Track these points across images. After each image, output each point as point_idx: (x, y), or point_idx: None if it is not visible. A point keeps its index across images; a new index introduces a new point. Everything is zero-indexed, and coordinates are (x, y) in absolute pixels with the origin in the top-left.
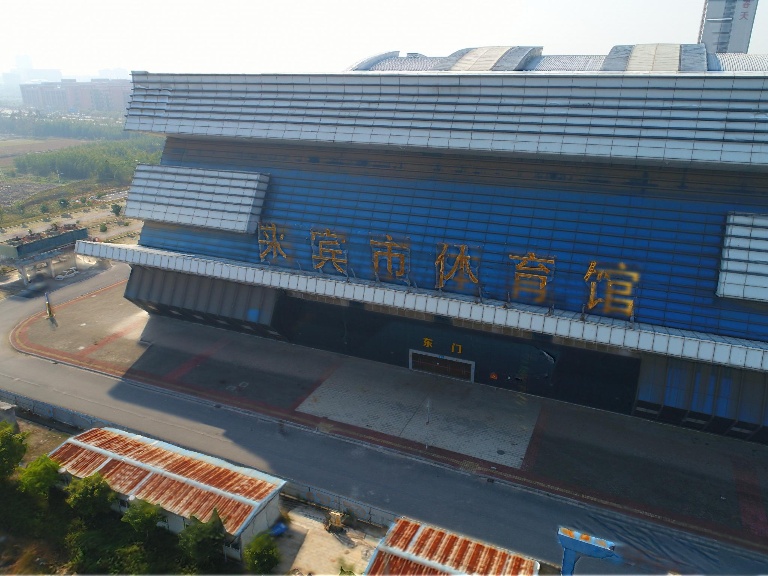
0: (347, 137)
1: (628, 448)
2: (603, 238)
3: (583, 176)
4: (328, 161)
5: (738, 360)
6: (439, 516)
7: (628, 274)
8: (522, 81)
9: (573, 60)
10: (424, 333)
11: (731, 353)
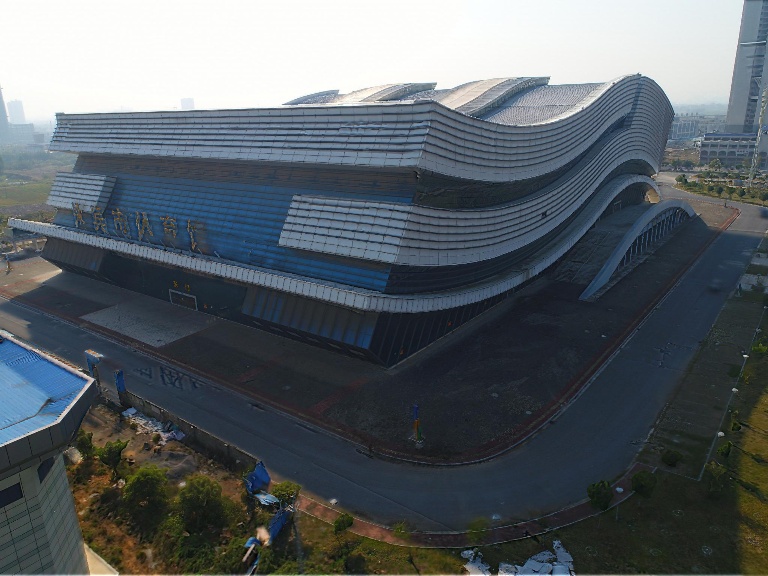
0: (135, 151)
1: (234, 344)
2: (248, 213)
3: (249, 173)
4: (143, 168)
5: (245, 278)
6: (84, 360)
7: (254, 235)
8: (209, 114)
9: None
10: (173, 278)
11: (243, 273)
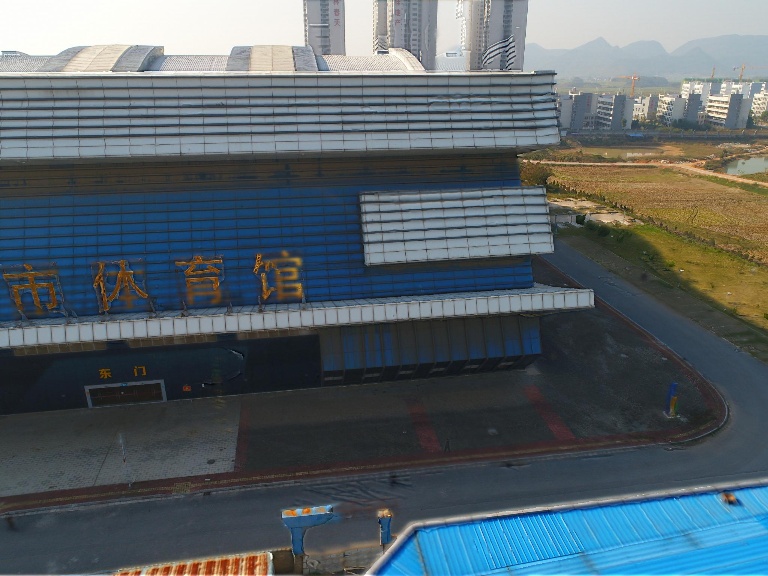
0: None
1: (325, 417)
2: (263, 231)
3: (231, 174)
4: None
5: (392, 315)
6: (160, 552)
7: (292, 260)
8: (149, 82)
9: (197, 60)
10: (98, 364)
11: (386, 311)
